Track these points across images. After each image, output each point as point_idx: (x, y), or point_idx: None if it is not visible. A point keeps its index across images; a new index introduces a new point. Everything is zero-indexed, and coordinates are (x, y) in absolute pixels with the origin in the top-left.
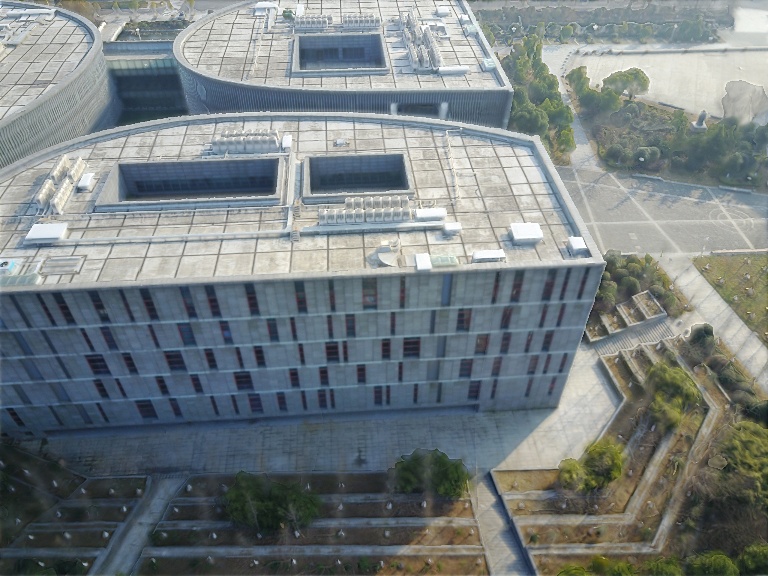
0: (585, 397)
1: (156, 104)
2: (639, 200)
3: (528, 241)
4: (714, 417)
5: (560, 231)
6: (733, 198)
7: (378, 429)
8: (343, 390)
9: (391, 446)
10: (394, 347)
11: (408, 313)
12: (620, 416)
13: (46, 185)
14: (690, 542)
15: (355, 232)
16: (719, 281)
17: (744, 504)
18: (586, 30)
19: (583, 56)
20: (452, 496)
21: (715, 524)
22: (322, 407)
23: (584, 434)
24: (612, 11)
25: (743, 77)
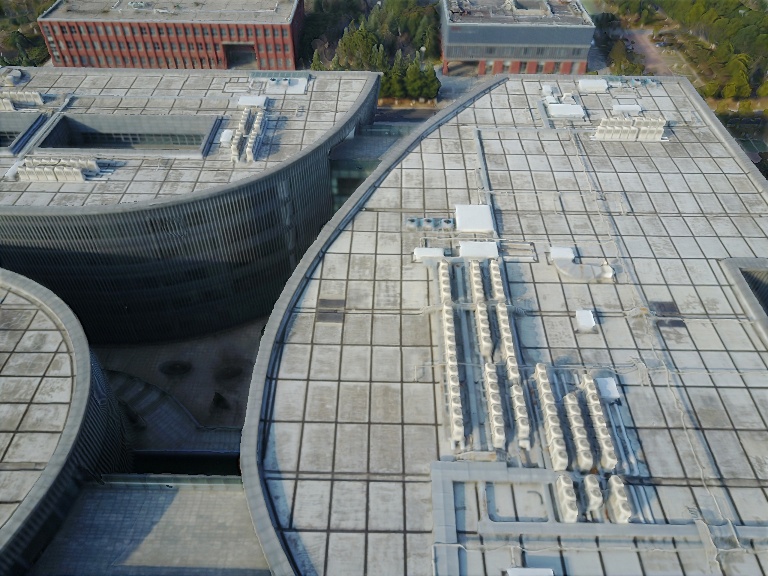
0: None
1: None
2: None
3: None
4: None
5: None
6: None
7: None
8: None
9: None
10: None
11: None
12: None
13: (256, 119)
14: None
15: None
16: None
17: None
18: None
19: None
20: None
21: None
22: None
23: None
24: None
25: None
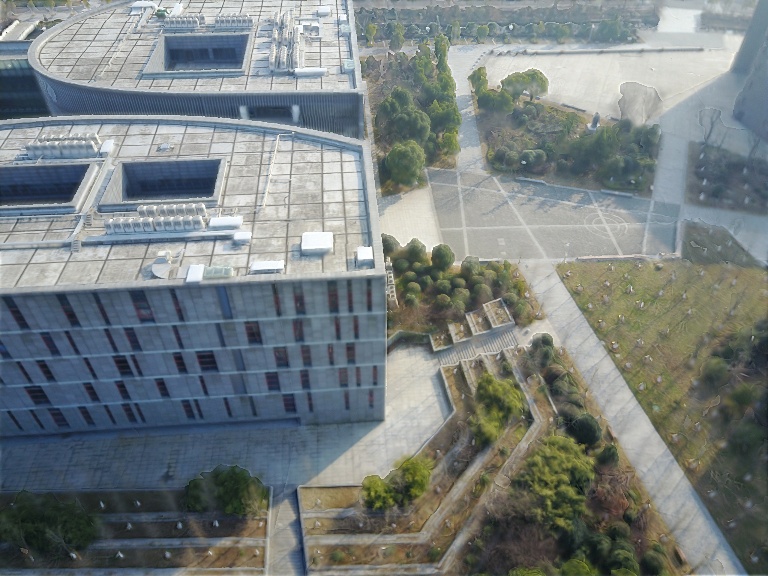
0: (416, 409)
1: (26, 105)
2: (516, 204)
3: (315, 251)
4: (536, 430)
5: (356, 240)
6: (613, 202)
7: (194, 444)
8: (148, 404)
9: (203, 461)
10: (188, 361)
11: (190, 326)
12: (445, 429)
13: None
14: (474, 563)
15: (141, 242)
16: (577, 288)
17: (530, 524)
18: (505, 30)
19: (497, 56)
20: (245, 515)
21: (498, 545)
22: (132, 421)
23: (405, 448)
24: (537, 10)
25: (653, 78)
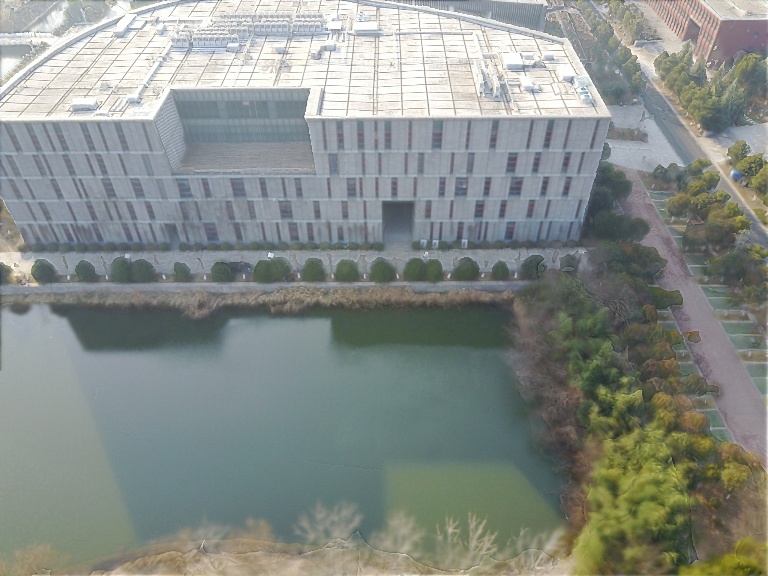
0: None
1: None
2: None
3: None
4: None
5: None
6: None
7: None
8: None
9: None
10: None
11: None
12: None
13: None
14: None
15: None
16: None
17: None
18: None
19: None
20: None
21: None
22: None
23: None
24: None
25: None
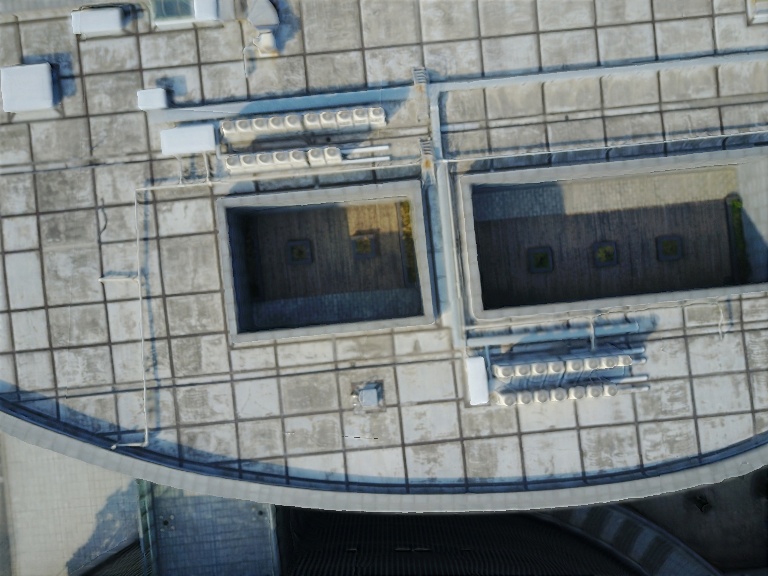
0: None
1: None
2: None
3: None
4: None
5: None
6: None
7: None
8: None
9: None
10: None
11: None
12: None
13: None
14: None
15: None
16: None
17: None
18: None
19: None
20: None
21: None
22: None
23: None
24: None
25: None
